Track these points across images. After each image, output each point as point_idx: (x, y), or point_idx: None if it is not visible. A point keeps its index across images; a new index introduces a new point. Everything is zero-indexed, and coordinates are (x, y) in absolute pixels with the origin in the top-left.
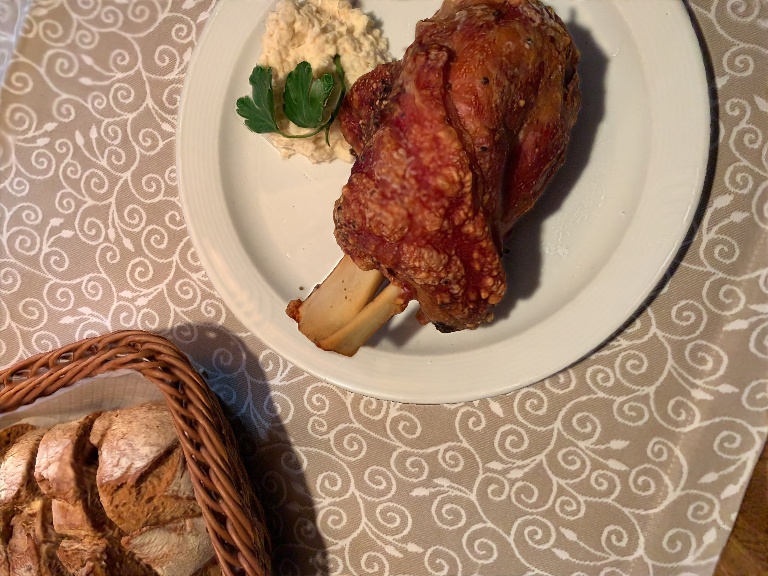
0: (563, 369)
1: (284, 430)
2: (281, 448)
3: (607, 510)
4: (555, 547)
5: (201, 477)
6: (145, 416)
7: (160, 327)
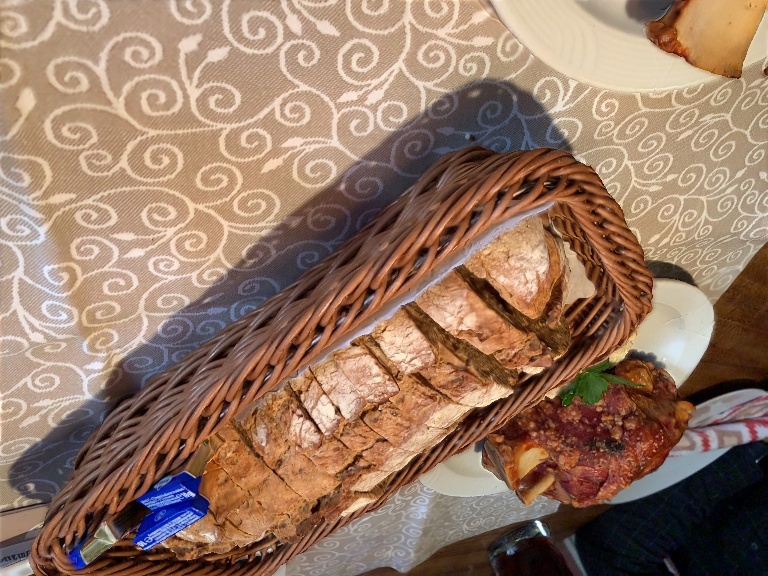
0: None
1: (569, 149)
2: None
3: None
4: None
5: (611, 247)
6: None
7: (410, 116)
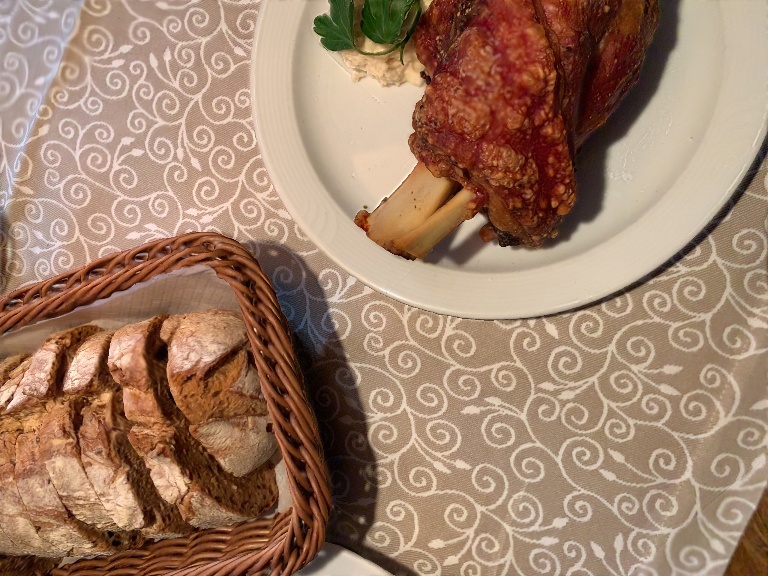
0: (620, 293)
1: (340, 346)
2: (336, 364)
3: (656, 434)
4: (602, 468)
5: (268, 372)
6: (212, 318)
7: None
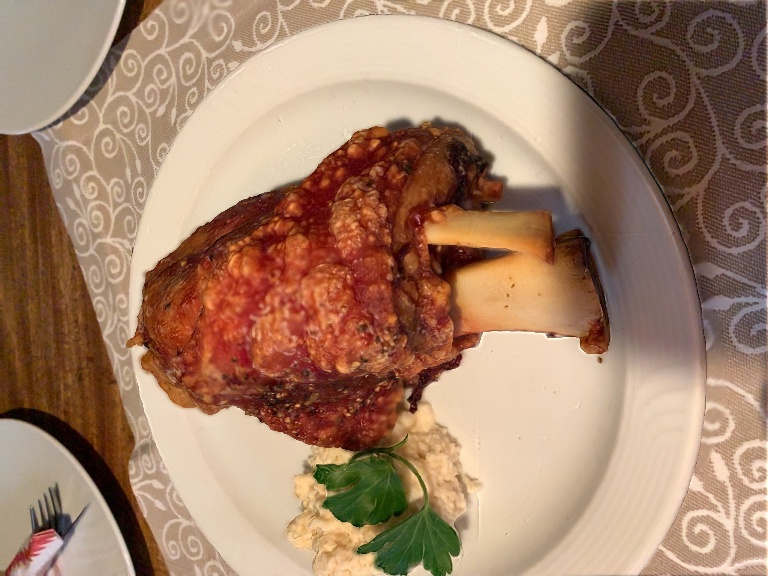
0: None
1: None
2: None
3: None
4: None
5: None
6: None
7: None
